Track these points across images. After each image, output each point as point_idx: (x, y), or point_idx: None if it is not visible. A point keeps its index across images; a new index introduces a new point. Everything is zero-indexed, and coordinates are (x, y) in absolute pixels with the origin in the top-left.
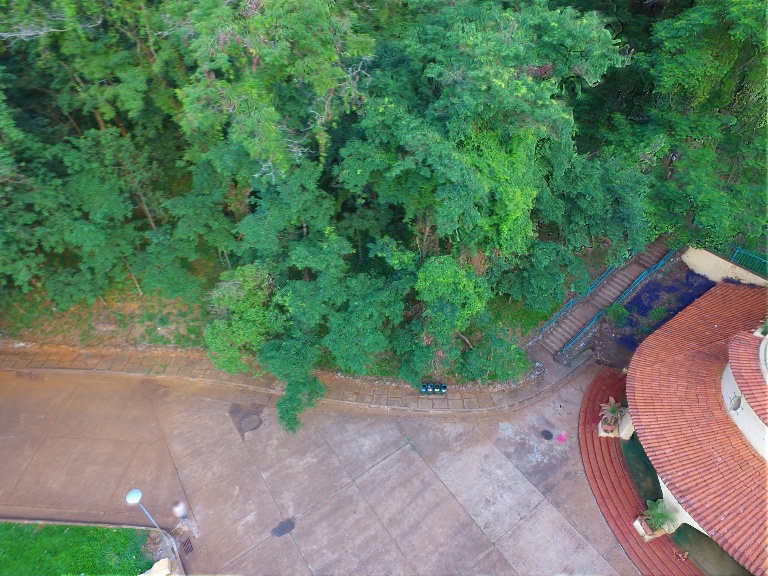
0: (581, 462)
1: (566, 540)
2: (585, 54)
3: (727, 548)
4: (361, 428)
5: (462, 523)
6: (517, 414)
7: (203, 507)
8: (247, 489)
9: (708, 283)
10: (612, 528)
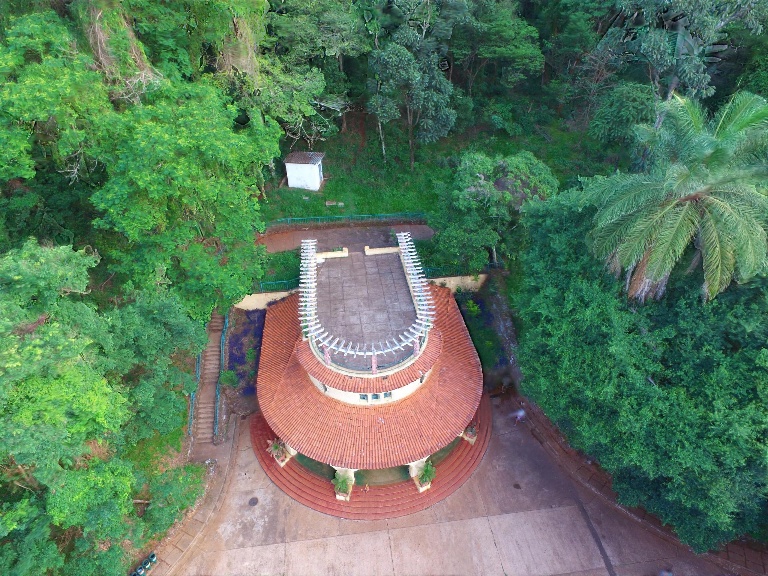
0: (286, 495)
1: (316, 552)
2: None
3: (375, 467)
4: None
5: None
6: (223, 510)
7: None
8: None
9: (262, 312)
10: (330, 514)
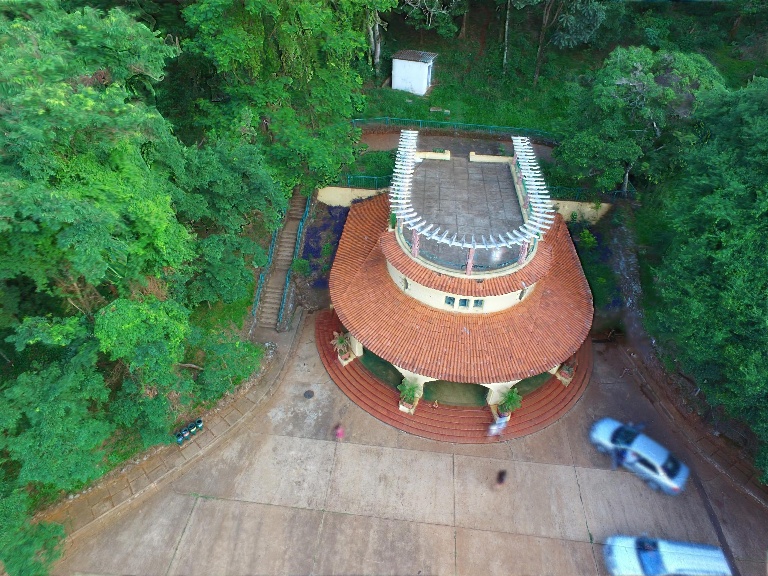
0: (344, 395)
1: (368, 459)
2: (134, 51)
3: (452, 379)
4: (138, 526)
5: (290, 519)
6: (277, 396)
7: None
8: None
9: (345, 210)
10: (390, 424)
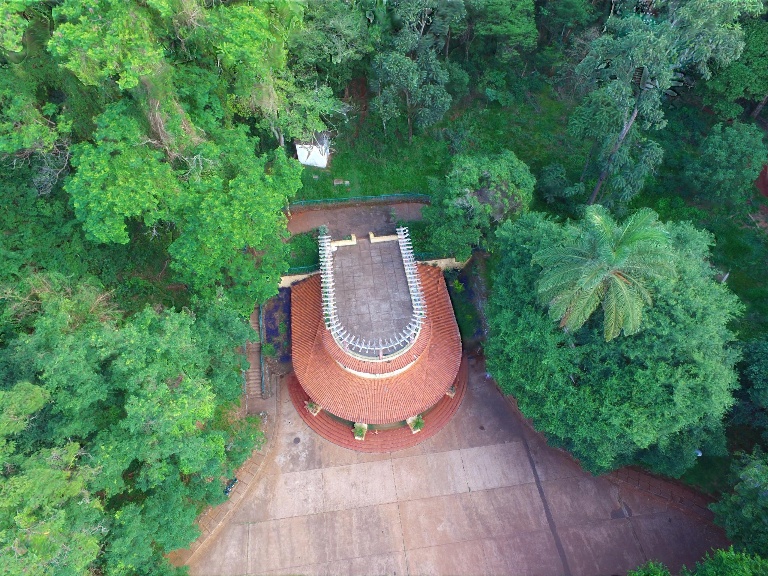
0: (319, 436)
1: (343, 475)
2: None
3: (382, 422)
4: (220, 550)
5: (306, 522)
6: (277, 447)
7: None
8: None
9: (287, 290)
10: (351, 449)
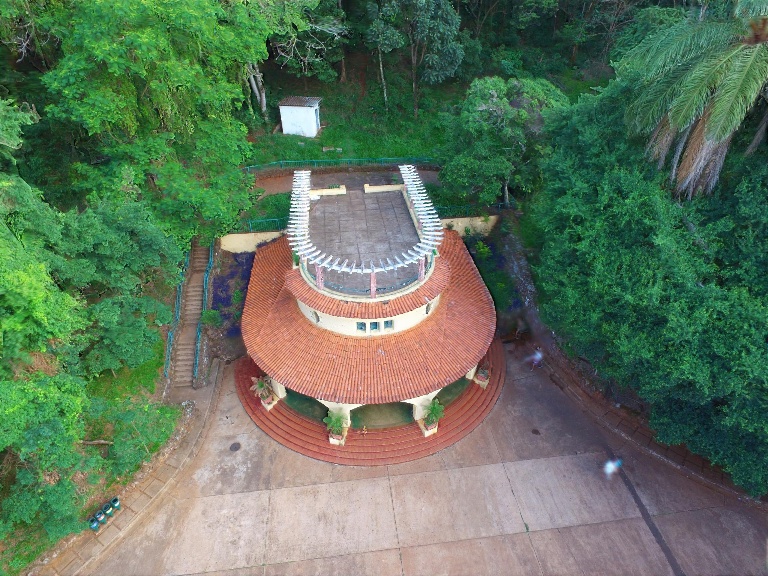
0: (272, 440)
1: (305, 500)
2: None
3: (374, 402)
4: None
5: None
6: (201, 456)
7: None
8: None
9: (251, 255)
10: (322, 459)
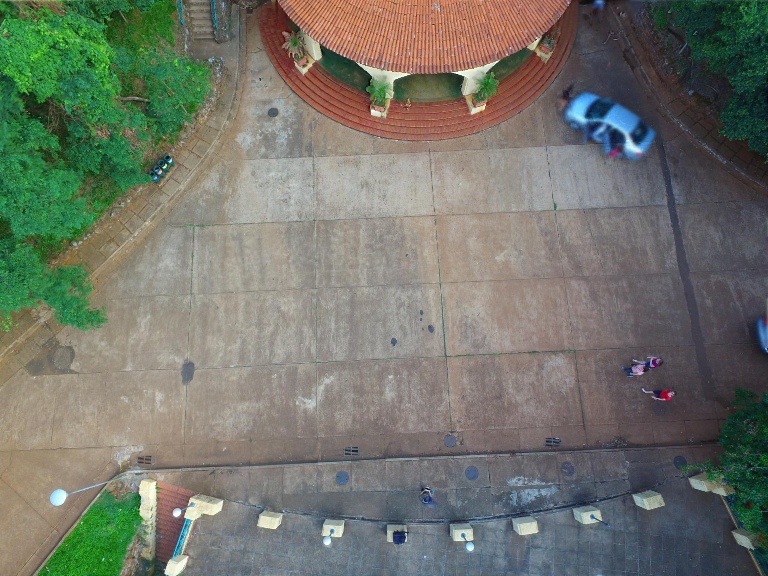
0: (310, 108)
1: (347, 169)
2: None
3: (424, 71)
4: (149, 259)
5: (285, 232)
6: (239, 119)
7: (118, 435)
8: (130, 389)
9: None
10: (363, 131)
